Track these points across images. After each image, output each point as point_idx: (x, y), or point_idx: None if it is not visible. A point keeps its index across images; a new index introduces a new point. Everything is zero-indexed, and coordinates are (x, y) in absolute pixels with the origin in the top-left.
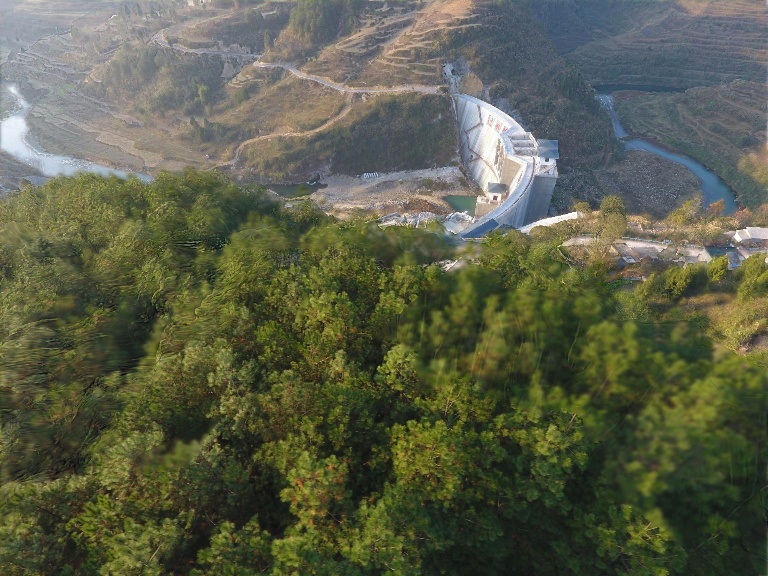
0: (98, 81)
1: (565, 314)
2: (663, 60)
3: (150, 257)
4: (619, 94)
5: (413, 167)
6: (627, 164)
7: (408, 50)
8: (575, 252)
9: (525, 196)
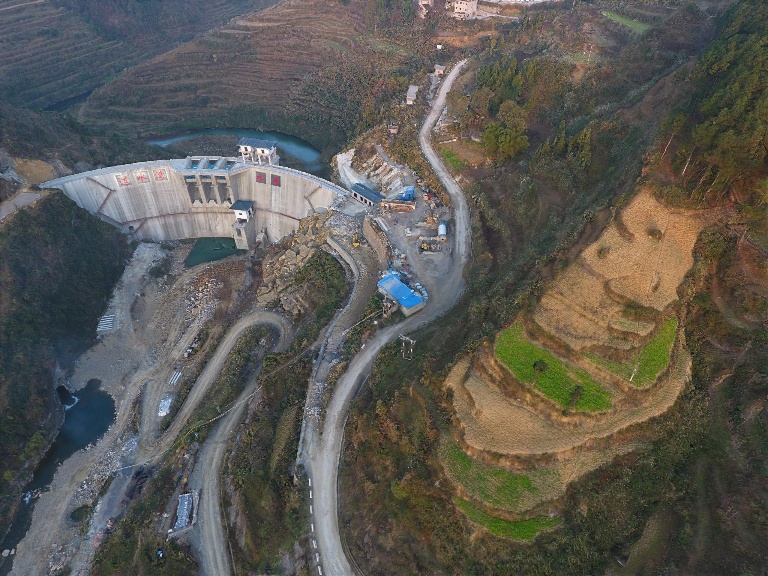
0: None
1: None
2: (10, 88)
3: None
4: None
5: (113, 280)
6: (193, 154)
7: None
8: (443, 138)
9: None
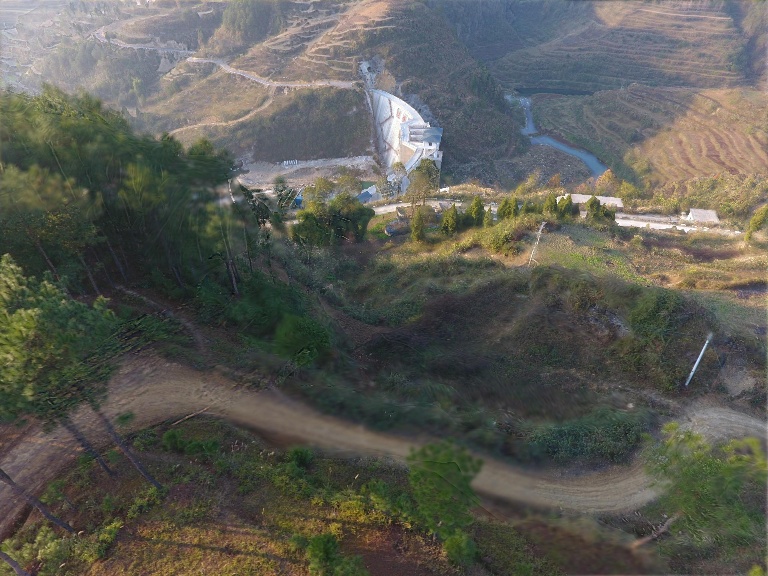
0: (38, 73)
1: (155, 161)
2: (580, 67)
3: None
4: (537, 96)
5: (331, 156)
6: (528, 156)
7: (328, 48)
8: (410, 211)
9: None
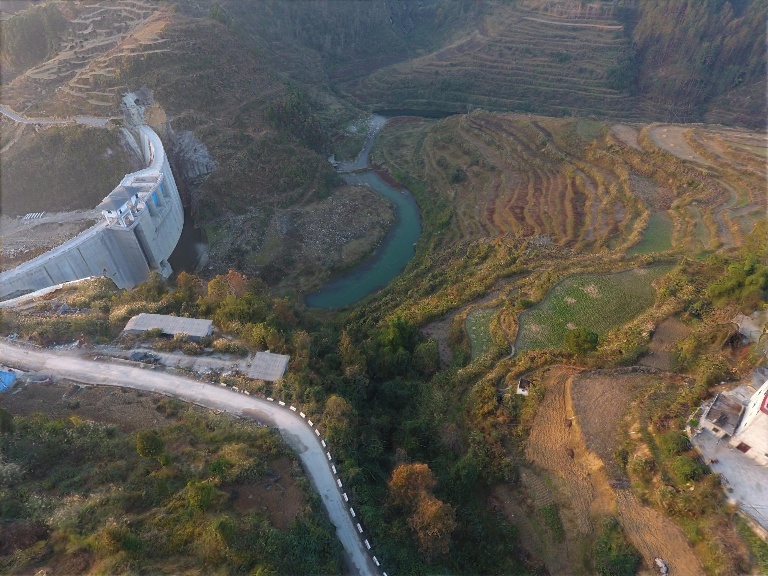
0: None
1: None
2: (449, 84)
3: None
4: (392, 120)
5: (87, 206)
6: (327, 202)
7: (88, 77)
8: None
9: (72, 254)
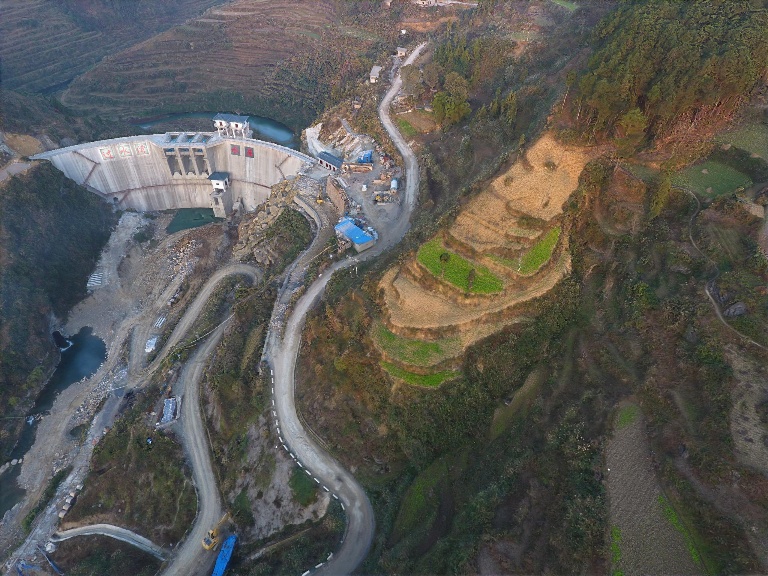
0: None
1: None
2: None
3: (674, 0)
4: None
5: (100, 244)
6: None
7: None
8: (400, 110)
9: None
